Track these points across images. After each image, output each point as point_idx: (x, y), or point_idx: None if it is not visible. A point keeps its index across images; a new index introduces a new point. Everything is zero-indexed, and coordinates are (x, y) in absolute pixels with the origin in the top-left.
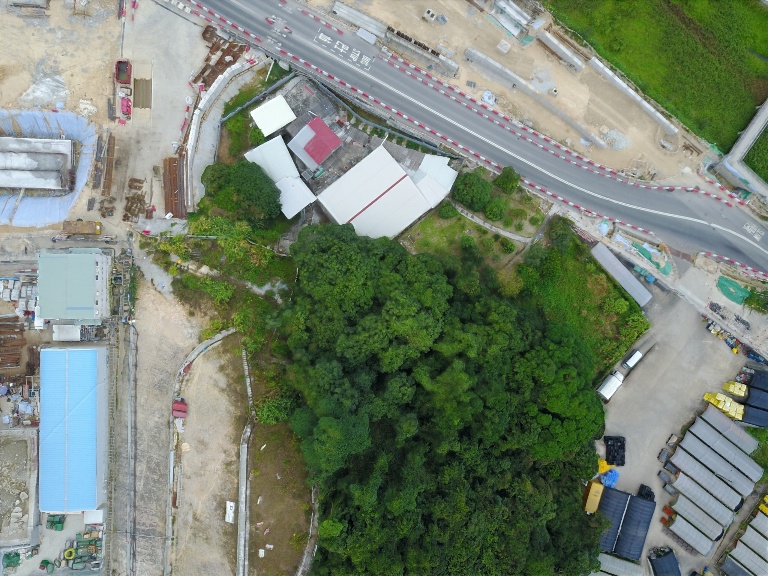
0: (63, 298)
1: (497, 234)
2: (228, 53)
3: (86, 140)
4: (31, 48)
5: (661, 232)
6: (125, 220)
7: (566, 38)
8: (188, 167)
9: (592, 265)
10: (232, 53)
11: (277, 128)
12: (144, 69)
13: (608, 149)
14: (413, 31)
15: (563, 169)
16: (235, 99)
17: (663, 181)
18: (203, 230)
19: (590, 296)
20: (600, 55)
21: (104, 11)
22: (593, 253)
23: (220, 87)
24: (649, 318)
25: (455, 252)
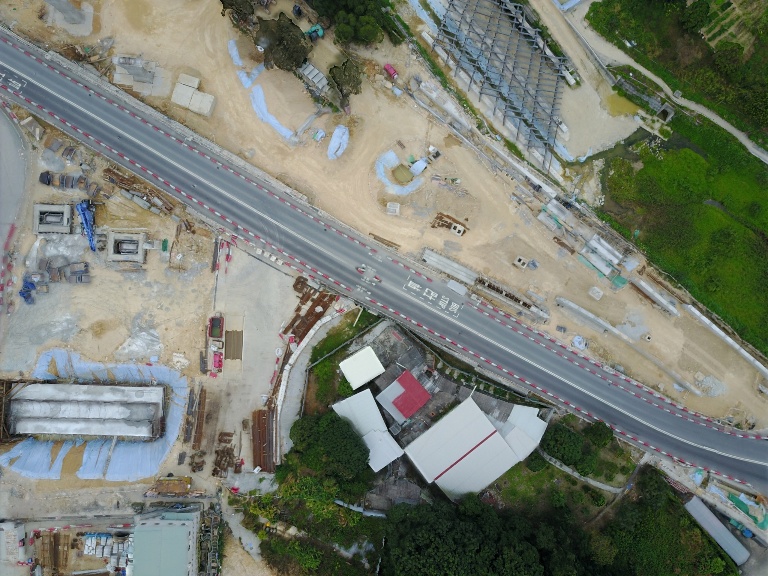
0: (157, 572)
1: (587, 485)
2: (318, 303)
3: (177, 390)
4: (128, 302)
5: (759, 483)
6: (214, 474)
7: (660, 280)
8: (277, 423)
9: (686, 520)
10: (322, 303)
11: (366, 381)
12: (236, 321)
13: (703, 395)
14: (503, 277)
15: (655, 416)
16: (322, 343)
17: (761, 430)
18: (292, 493)
19: (684, 553)
20: (695, 298)
21: (198, 264)
22: (688, 509)
23: (310, 339)
24: (746, 575)
25: (543, 502)
